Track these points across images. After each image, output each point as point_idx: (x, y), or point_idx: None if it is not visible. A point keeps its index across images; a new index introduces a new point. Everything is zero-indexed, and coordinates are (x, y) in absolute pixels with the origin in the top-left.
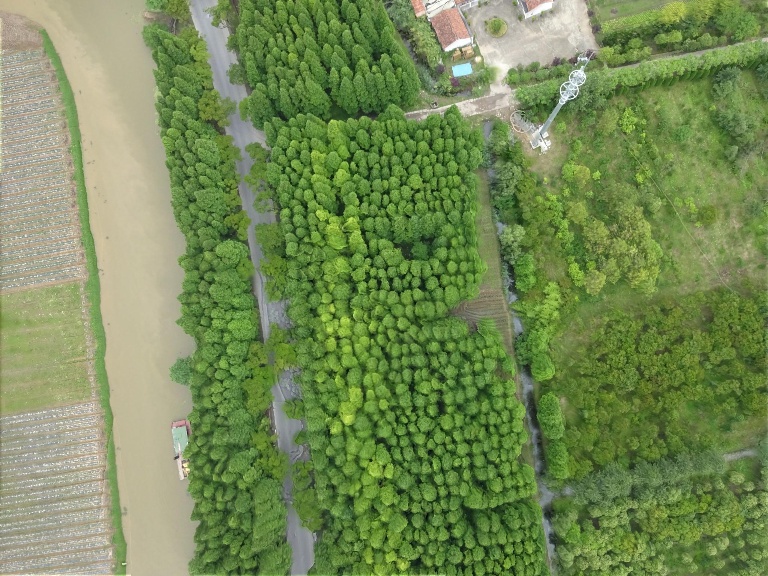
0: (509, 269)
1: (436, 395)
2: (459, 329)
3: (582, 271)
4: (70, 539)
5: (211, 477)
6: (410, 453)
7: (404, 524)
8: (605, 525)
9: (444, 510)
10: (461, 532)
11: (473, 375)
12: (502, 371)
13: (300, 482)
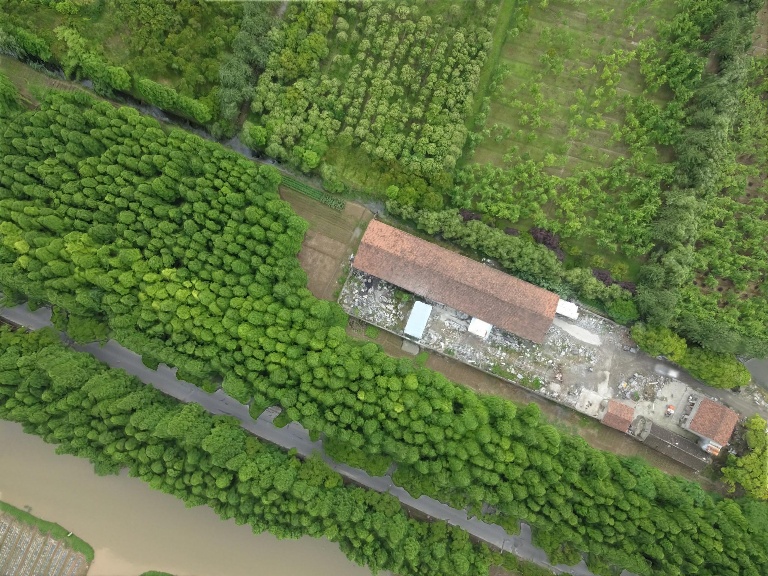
0: (33, 60)
1: (61, 167)
2: (20, 116)
3: (65, 1)
4: (19, 571)
5: (6, 397)
6: (82, 212)
7: (131, 250)
8: (269, 105)
9: (148, 214)
10: (173, 210)
11: (64, 127)
12: (86, 106)
13: (57, 322)
